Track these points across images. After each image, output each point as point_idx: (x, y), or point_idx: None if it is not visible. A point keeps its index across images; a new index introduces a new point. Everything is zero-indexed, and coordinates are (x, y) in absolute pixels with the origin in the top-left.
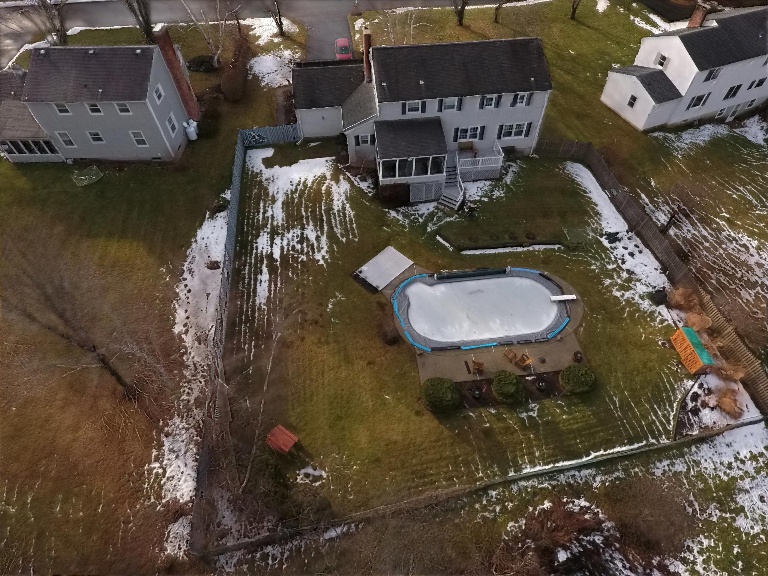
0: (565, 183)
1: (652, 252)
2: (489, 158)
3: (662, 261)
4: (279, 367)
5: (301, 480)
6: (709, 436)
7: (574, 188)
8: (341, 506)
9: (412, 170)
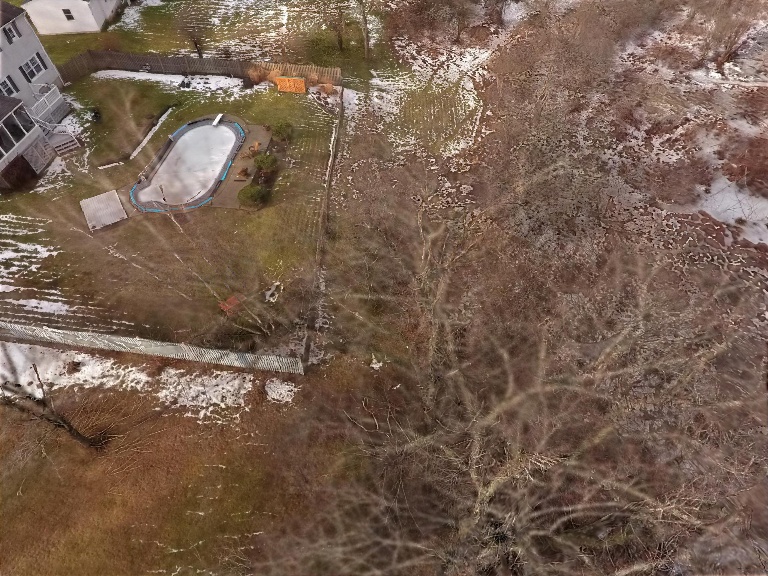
0: (113, 83)
1: (212, 74)
2: (49, 94)
3: (222, 73)
4: (158, 302)
5: (274, 299)
6: (342, 106)
7: (123, 82)
8: (306, 276)
9: (10, 138)
